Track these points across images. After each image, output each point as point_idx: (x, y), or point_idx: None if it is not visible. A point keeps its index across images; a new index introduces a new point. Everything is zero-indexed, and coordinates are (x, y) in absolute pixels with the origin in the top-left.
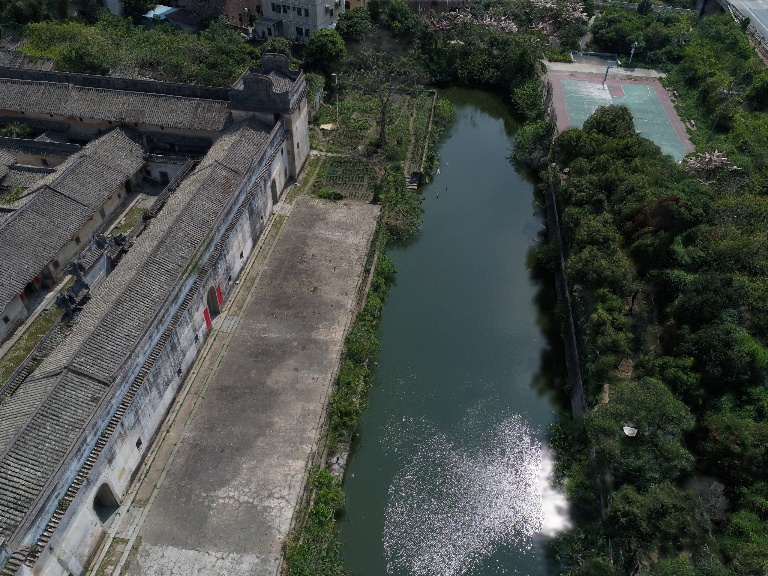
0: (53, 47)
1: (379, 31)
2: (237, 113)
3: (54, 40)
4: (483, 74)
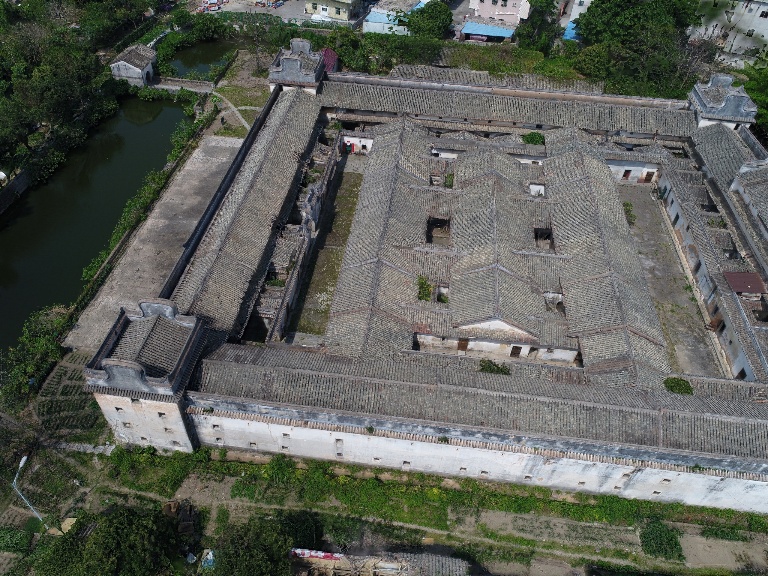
0: None
1: None
2: None
3: None
4: None
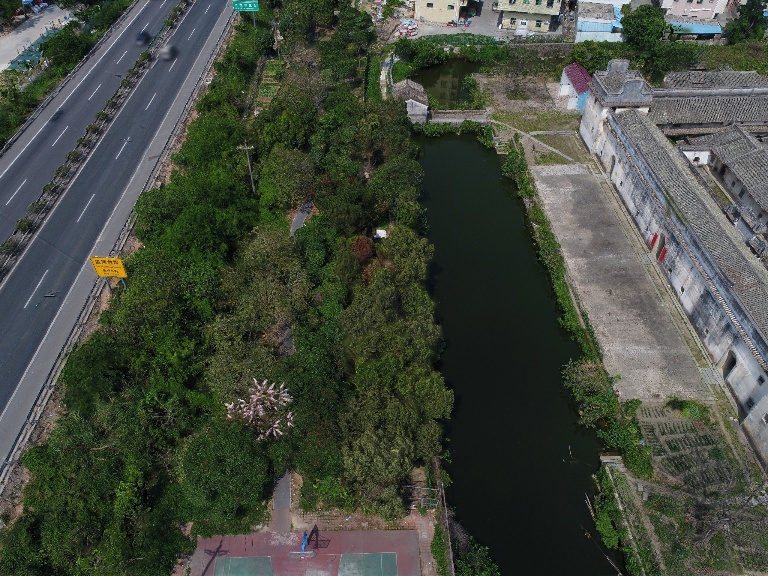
0: None
1: None
2: None
3: None
4: None
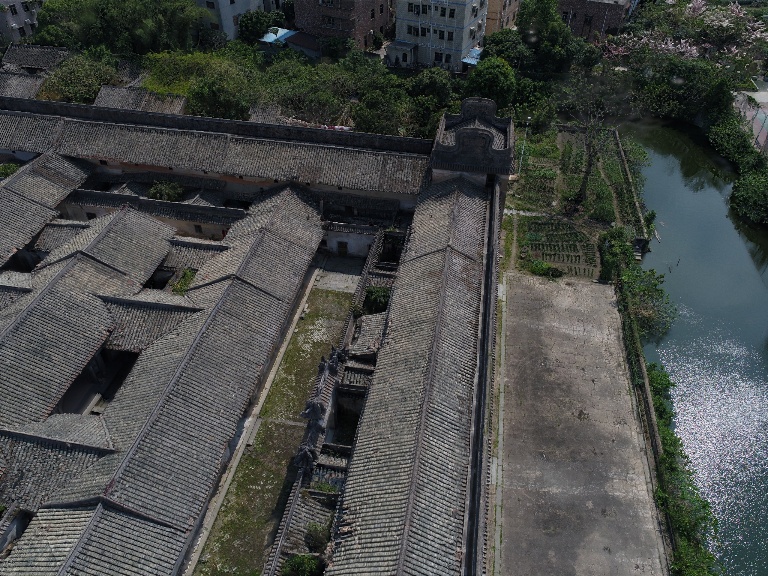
0: (178, 81)
1: (533, 57)
2: (439, 173)
3: (179, 73)
4: (662, 107)
